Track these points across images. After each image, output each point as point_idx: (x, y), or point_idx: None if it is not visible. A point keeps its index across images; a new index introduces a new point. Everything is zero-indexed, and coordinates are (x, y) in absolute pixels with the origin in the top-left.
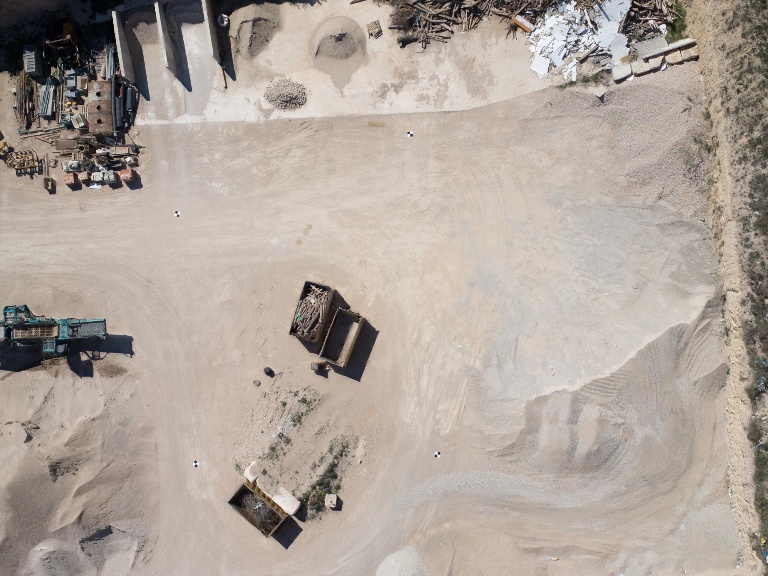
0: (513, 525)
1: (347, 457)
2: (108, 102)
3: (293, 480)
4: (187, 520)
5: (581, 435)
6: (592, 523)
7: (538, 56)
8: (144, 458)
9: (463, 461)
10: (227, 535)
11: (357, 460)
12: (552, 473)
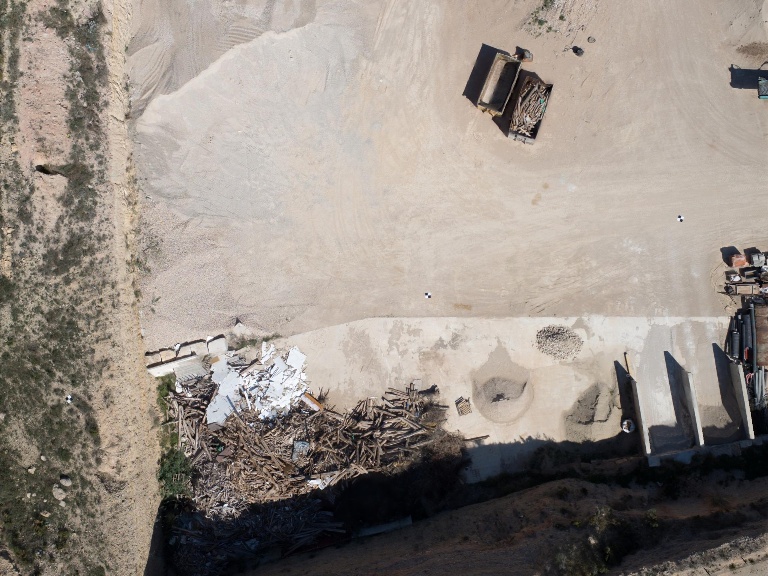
0: None
1: None
2: (761, 342)
3: None
4: None
5: None
6: None
7: (298, 368)
8: None
9: None
10: None
11: None
12: None
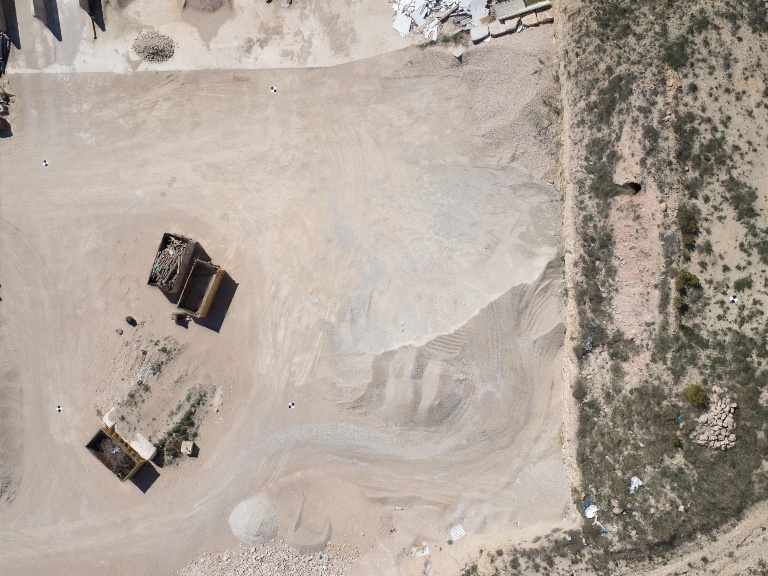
0: (361, 475)
1: (204, 406)
2: None
3: (150, 427)
4: (50, 463)
5: (425, 390)
6: (434, 475)
7: (400, 14)
8: (9, 402)
9: (316, 412)
10: (88, 478)
11: (214, 409)
12: (398, 426)
